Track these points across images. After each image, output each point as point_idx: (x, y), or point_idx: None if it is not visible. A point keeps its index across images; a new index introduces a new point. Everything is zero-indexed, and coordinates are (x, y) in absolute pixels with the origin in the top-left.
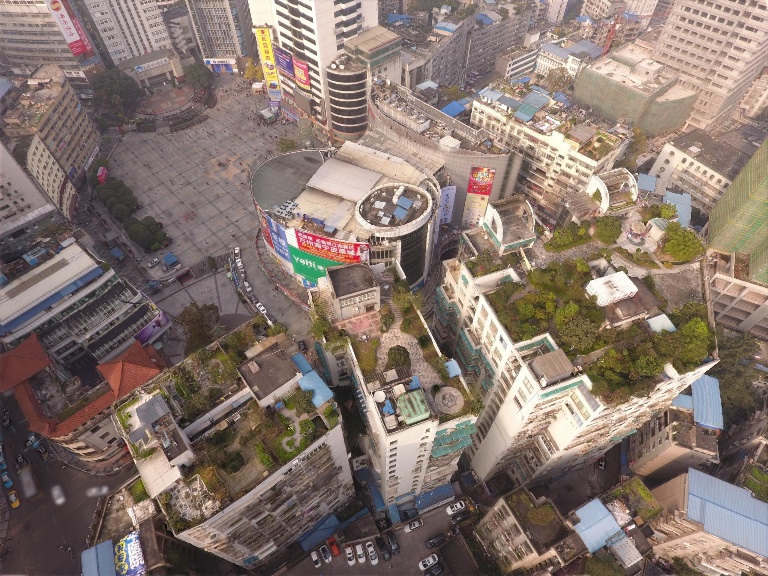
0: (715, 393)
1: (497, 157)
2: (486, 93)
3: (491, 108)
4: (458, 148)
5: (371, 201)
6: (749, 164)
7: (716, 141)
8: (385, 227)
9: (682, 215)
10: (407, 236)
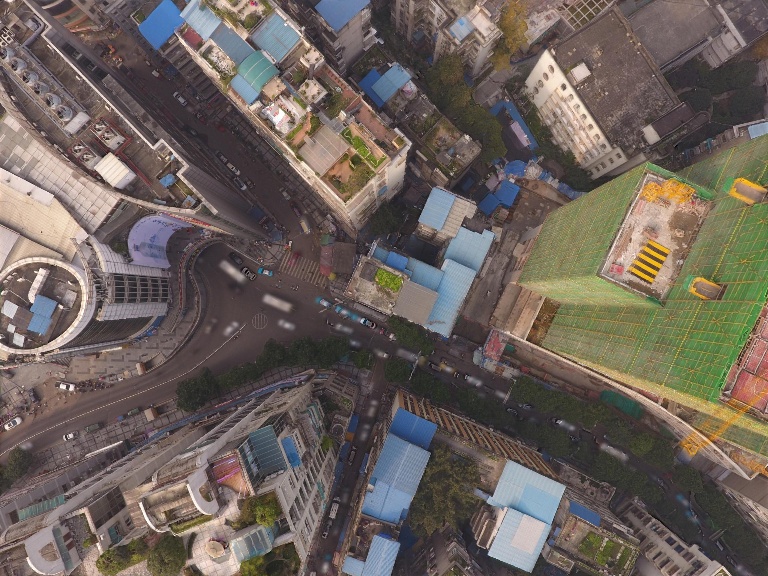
0: (390, 561)
1: (179, 212)
2: (192, 16)
3: (200, 57)
4: (117, 194)
5: (3, 294)
6: (580, 205)
7: (630, 42)
8: (20, 350)
9: (456, 289)
10: (66, 344)
